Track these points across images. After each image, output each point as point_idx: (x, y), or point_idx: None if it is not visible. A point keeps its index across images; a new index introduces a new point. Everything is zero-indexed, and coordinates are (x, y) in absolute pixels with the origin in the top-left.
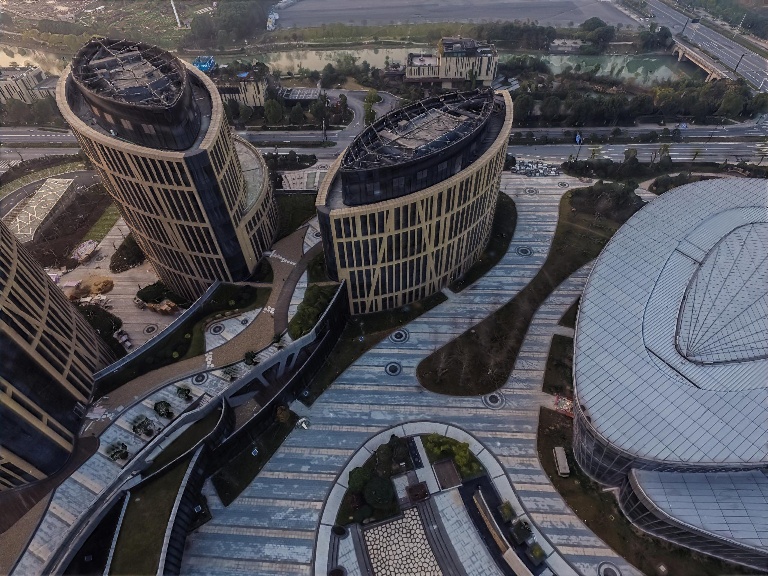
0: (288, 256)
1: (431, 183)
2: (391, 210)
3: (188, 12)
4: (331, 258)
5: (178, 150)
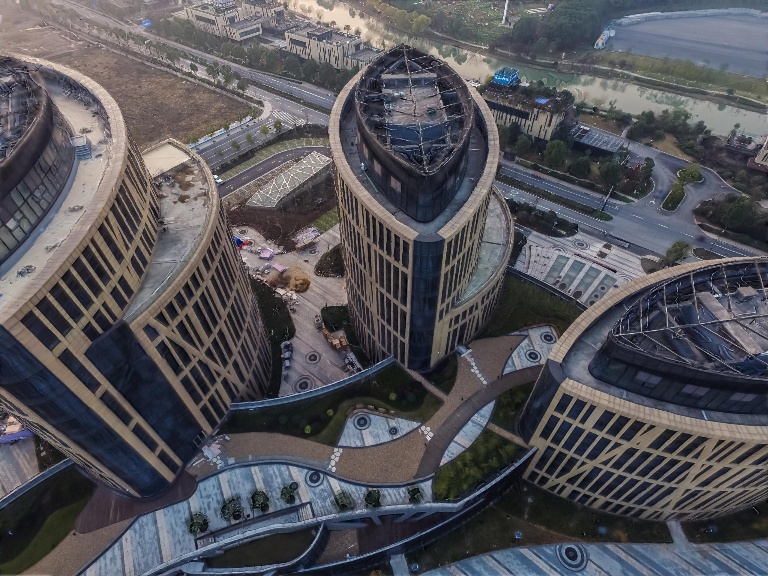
0: (483, 367)
1: (750, 410)
2: (659, 428)
3: (519, 9)
4: (533, 417)
5: (415, 220)
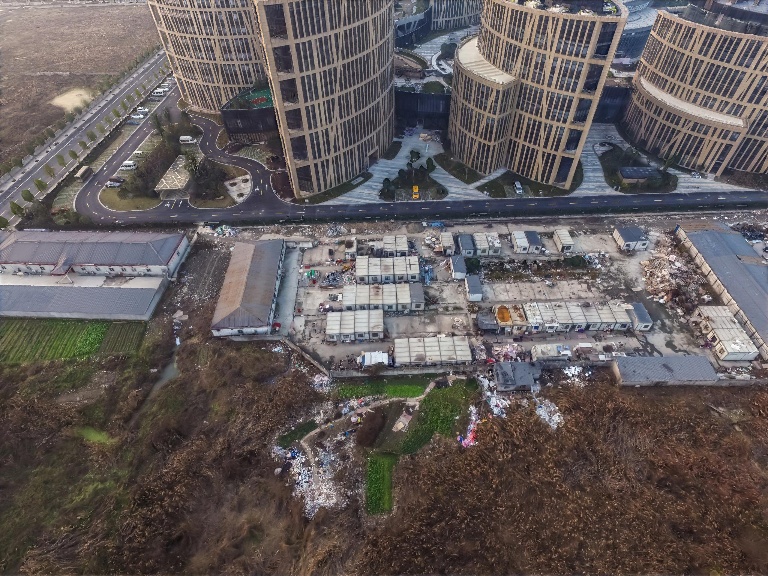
0: (406, 3)
1: None
2: None
3: None
4: None
5: None
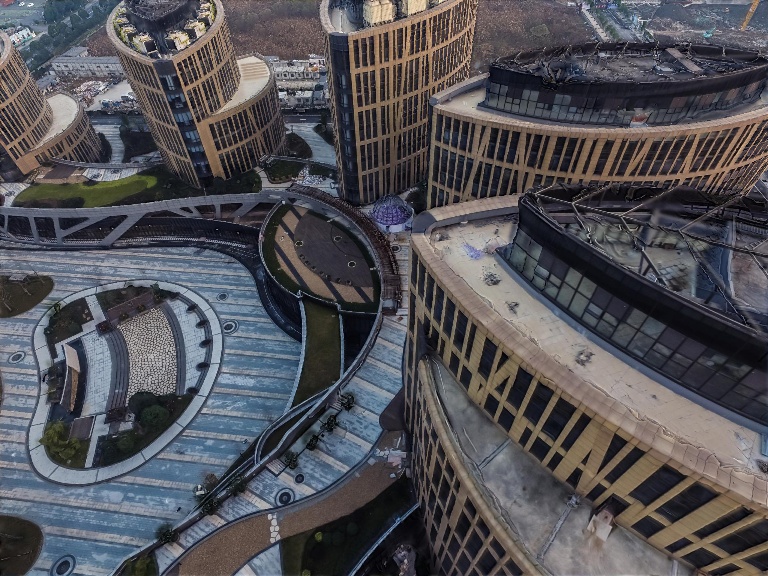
0: None
1: None
2: None
3: None
4: None
5: None
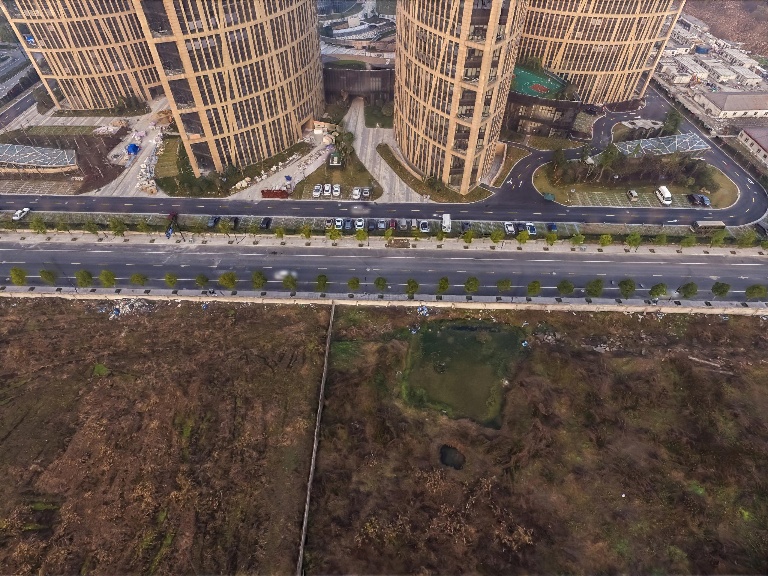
0: None
1: None
2: None
3: None
4: None
5: None
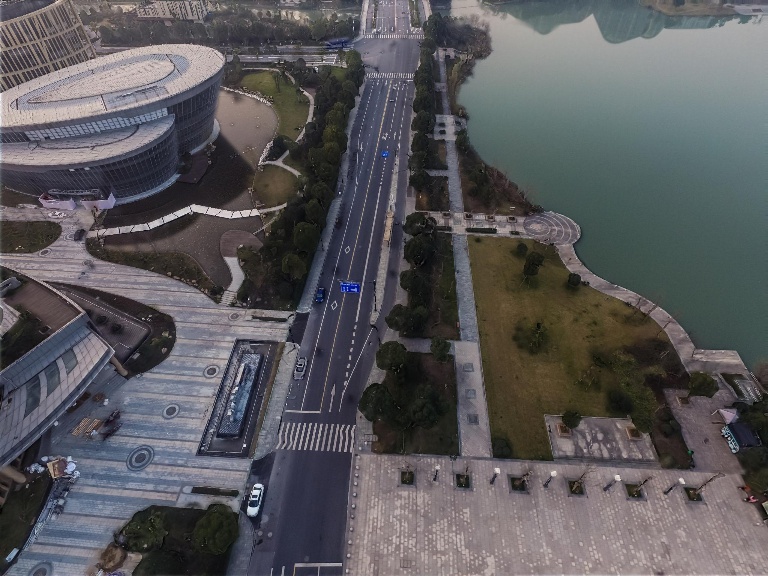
0: None
1: None
2: None
3: None
4: None
5: None
